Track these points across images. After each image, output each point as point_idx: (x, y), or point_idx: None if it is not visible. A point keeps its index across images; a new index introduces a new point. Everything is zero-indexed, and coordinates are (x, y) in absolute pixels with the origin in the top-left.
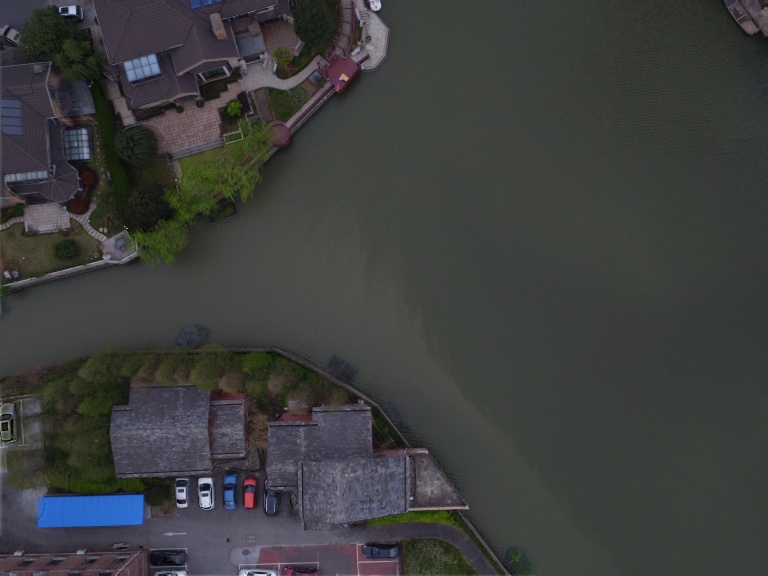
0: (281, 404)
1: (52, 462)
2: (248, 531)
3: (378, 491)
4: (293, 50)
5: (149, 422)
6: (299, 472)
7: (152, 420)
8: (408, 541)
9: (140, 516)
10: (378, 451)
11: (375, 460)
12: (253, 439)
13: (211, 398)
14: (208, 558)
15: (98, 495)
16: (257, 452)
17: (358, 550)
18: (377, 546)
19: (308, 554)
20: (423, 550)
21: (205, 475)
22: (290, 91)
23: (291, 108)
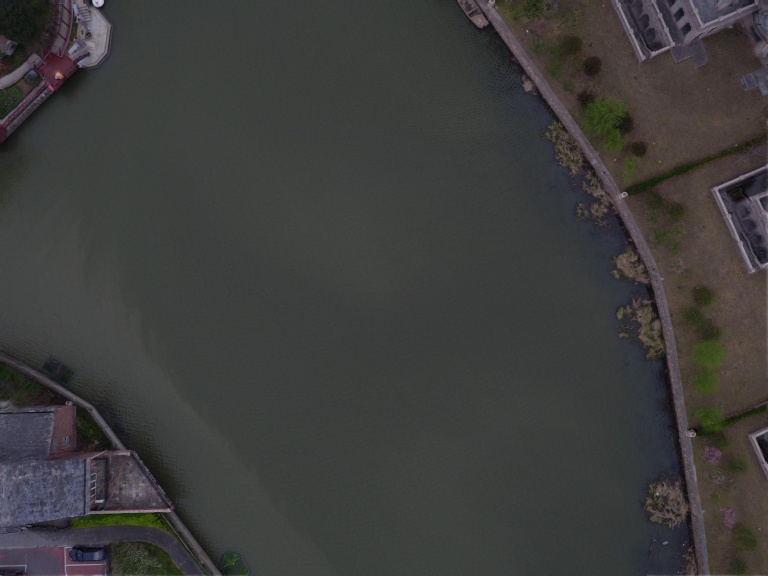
0: None
1: None
2: None
3: (51, 494)
4: (6, 49)
5: None
6: None
7: None
8: (117, 544)
9: None
10: (55, 453)
11: (48, 462)
12: None
13: None
14: None
15: None
16: None
17: (66, 553)
18: (82, 549)
19: (16, 557)
20: (128, 553)
21: None
22: (5, 90)
23: (4, 107)
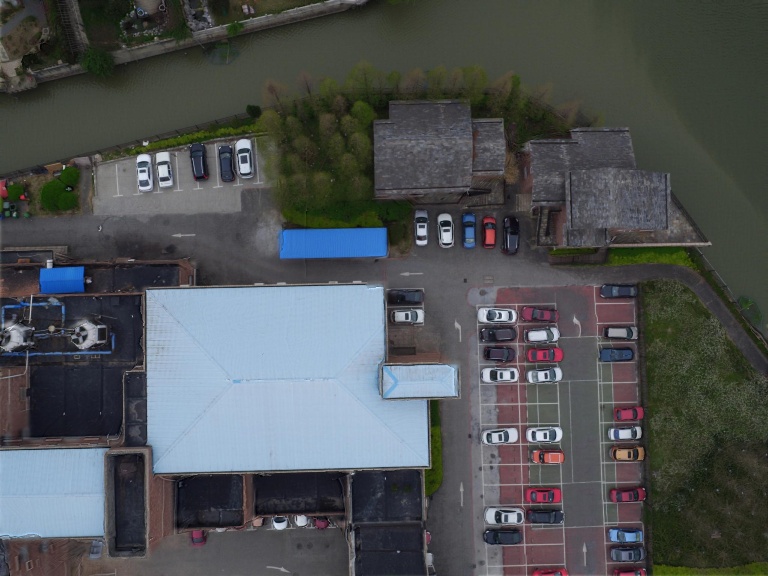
0: (522, 141)
1: (289, 199)
2: (485, 271)
3: (644, 203)
4: None
5: (413, 134)
6: (567, 182)
7: (415, 132)
8: (645, 283)
9: (385, 247)
10: (641, 166)
11: (641, 172)
12: (515, 154)
13: (472, 114)
14: (445, 298)
15: (340, 228)
16: (502, 185)
17: (595, 292)
18: (616, 285)
19: (545, 295)
20: (663, 289)
21: (447, 210)
22: None
23: None
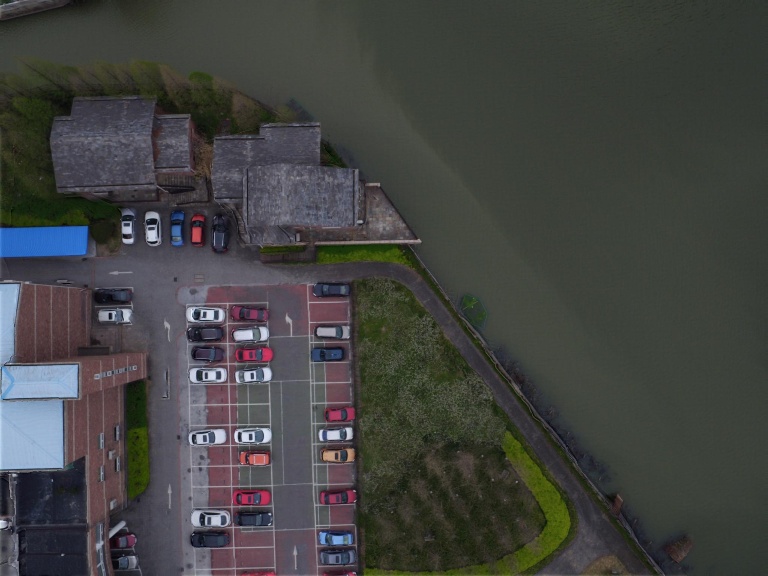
0: None
1: None
2: (196, 270)
3: (325, 199)
4: None
5: (91, 130)
6: (244, 178)
7: (94, 129)
8: (360, 282)
9: (84, 246)
10: (326, 162)
11: (322, 168)
12: (198, 151)
13: (155, 110)
14: (155, 297)
15: (41, 226)
16: (205, 182)
17: (309, 290)
18: (328, 284)
19: (257, 294)
20: (374, 287)
21: (152, 208)
22: None
23: None
